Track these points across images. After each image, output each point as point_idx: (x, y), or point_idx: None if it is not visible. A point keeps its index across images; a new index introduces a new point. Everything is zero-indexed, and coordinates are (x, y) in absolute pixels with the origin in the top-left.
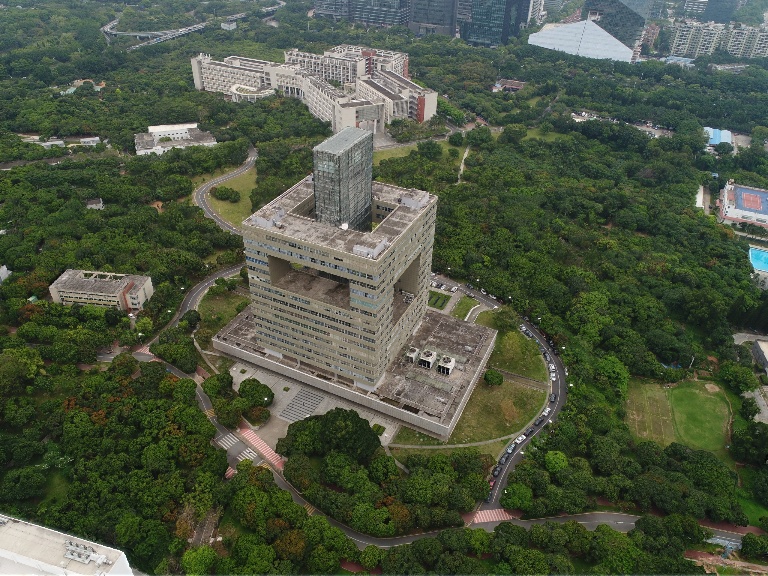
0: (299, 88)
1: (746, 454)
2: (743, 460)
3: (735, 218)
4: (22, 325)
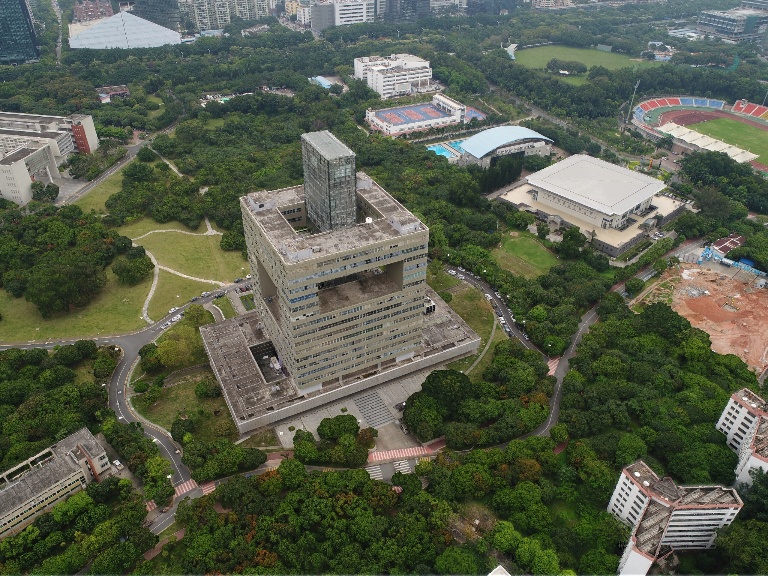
0: None
1: (574, 252)
2: (571, 258)
3: (396, 133)
4: None
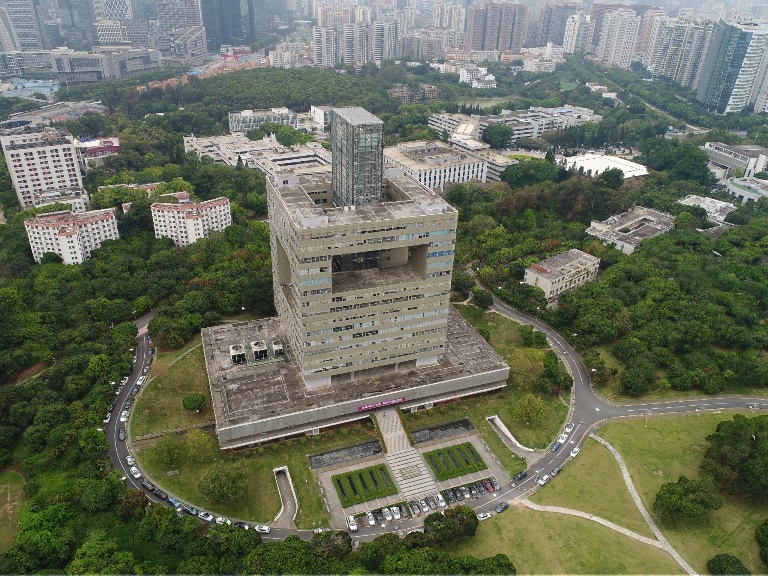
0: None
1: None
2: None
3: None
4: None
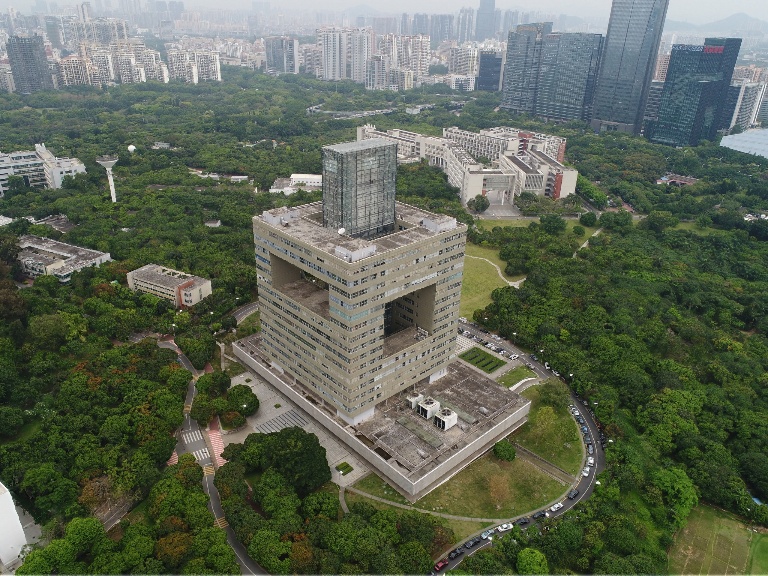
0: (444, 158)
1: None
2: None
3: None
4: None
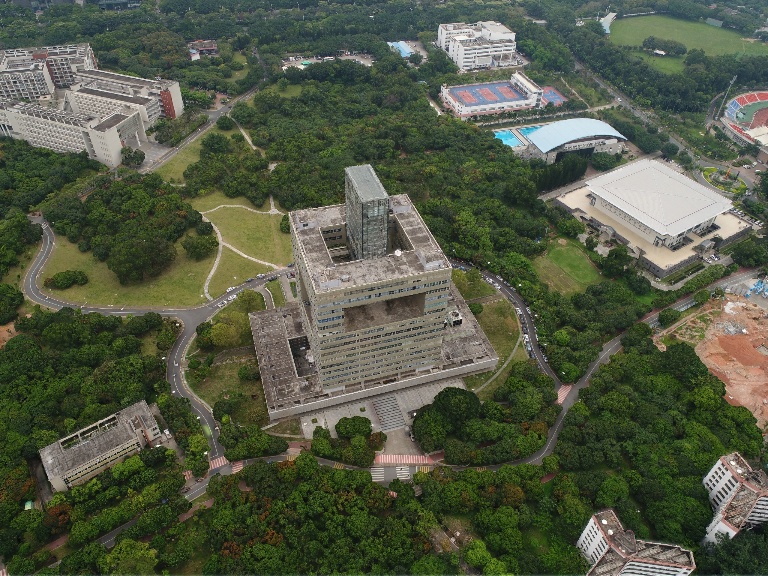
0: None
1: (617, 271)
2: None
3: (467, 114)
4: (71, 533)
